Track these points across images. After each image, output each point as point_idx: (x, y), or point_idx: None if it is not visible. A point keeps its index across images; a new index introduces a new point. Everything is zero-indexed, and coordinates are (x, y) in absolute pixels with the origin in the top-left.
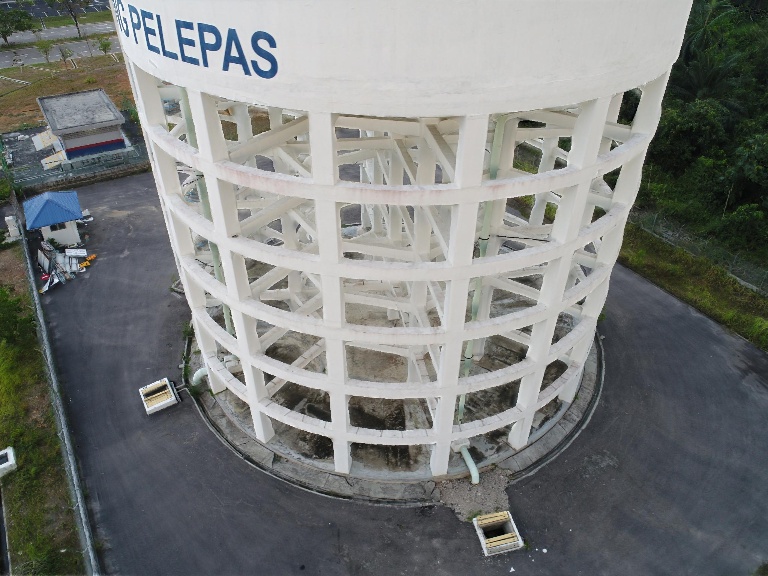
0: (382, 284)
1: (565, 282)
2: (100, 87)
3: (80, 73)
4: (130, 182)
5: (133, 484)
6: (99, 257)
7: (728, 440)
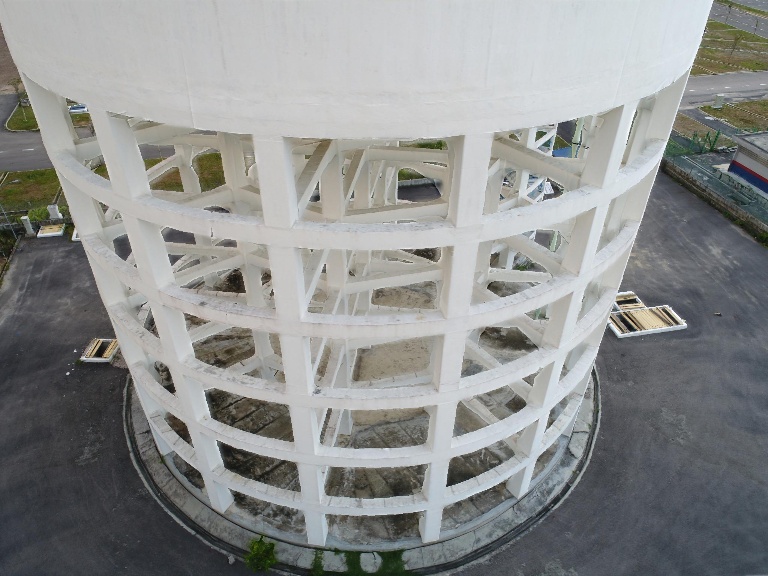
0: None
1: None
2: None
3: None
4: (701, 211)
5: None
6: None
7: None
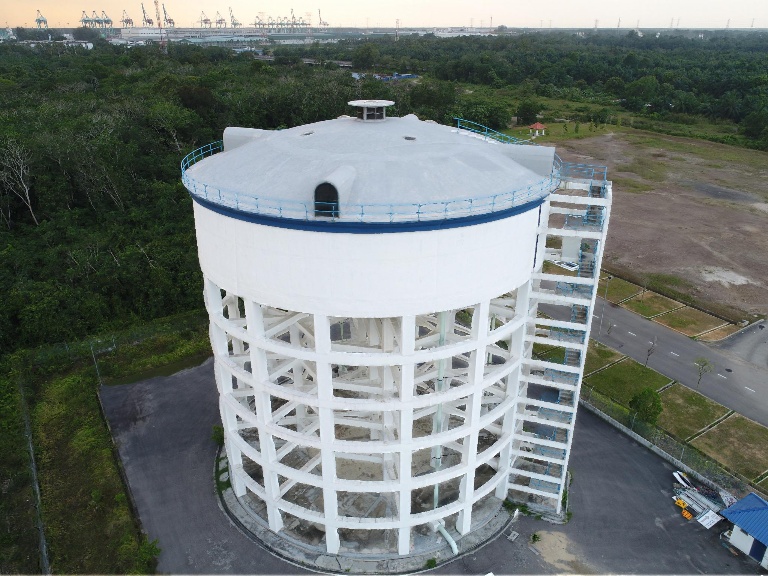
0: None
1: None
2: None
3: None
4: None
5: None
6: (681, 517)
7: (198, 385)
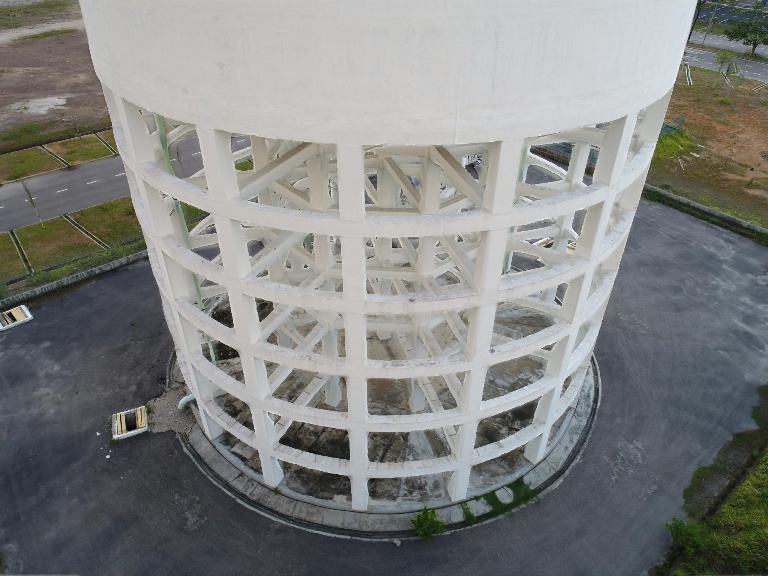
0: None
1: None
2: (720, 109)
3: (740, 94)
4: None
5: (210, 250)
6: None
7: None
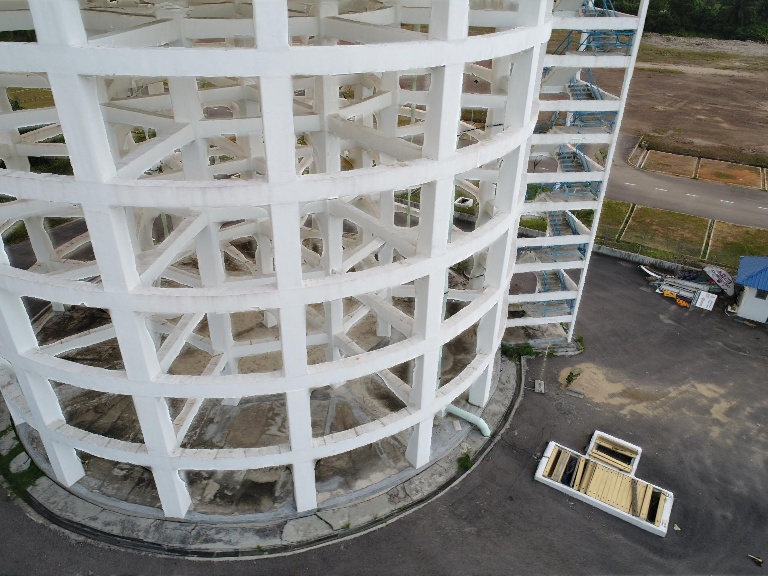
0: None
1: None
2: None
3: None
4: None
5: None
6: (680, 308)
7: None
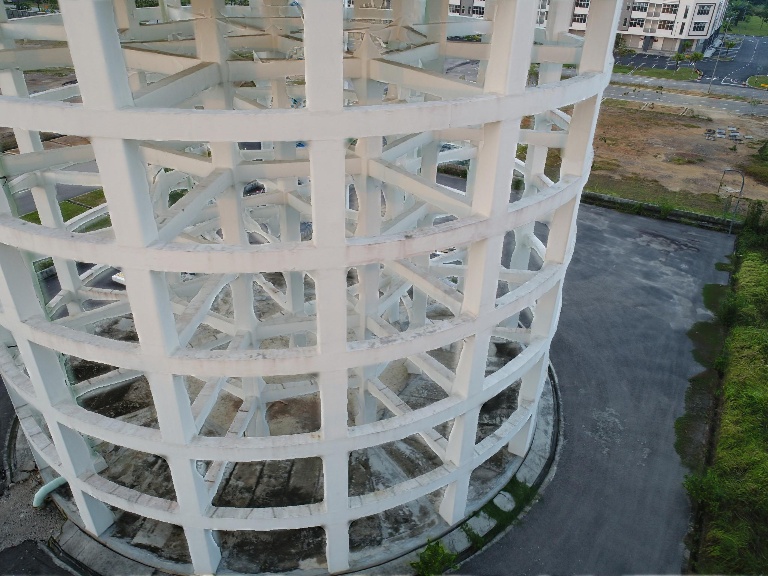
0: (284, 304)
1: (7, 288)
2: None
3: None
4: None
5: None
6: None
7: None
